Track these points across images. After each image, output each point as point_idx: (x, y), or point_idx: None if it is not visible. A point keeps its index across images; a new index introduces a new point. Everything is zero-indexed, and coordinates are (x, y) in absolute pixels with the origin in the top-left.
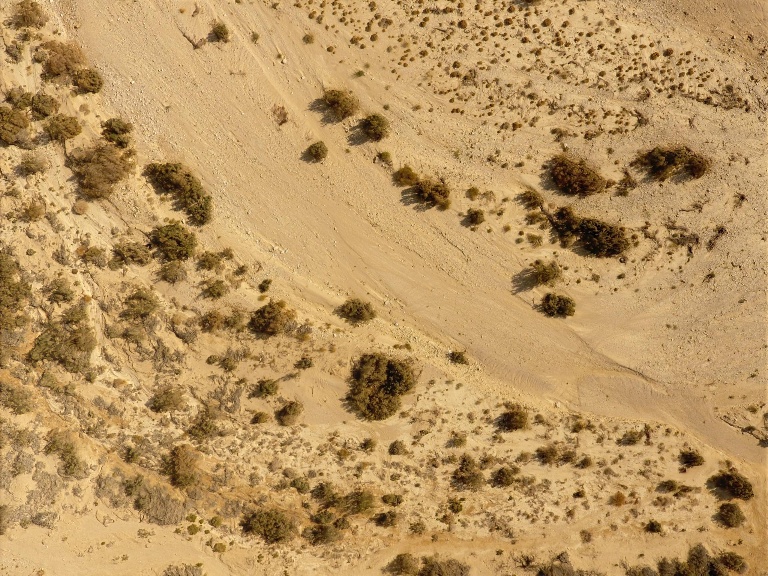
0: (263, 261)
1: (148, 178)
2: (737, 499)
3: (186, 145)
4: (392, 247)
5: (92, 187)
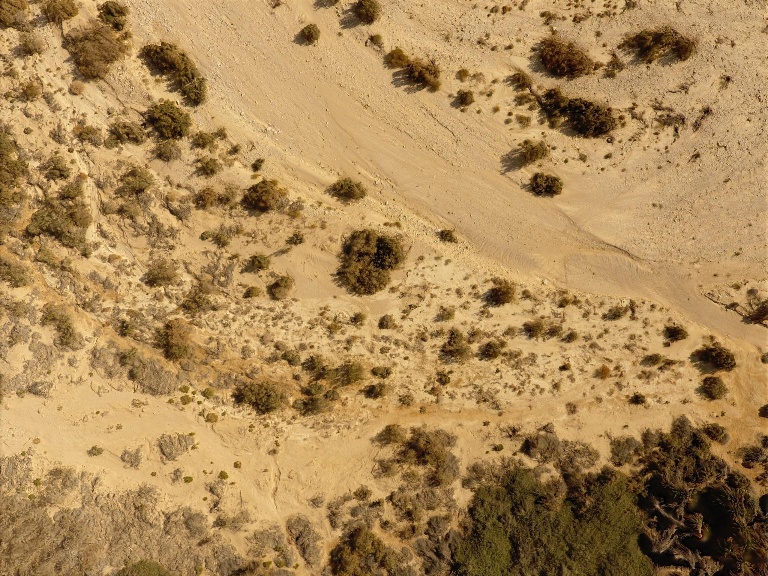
0: (256, 141)
1: (143, 60)
2: (720, 372)
3: (181, 28)
4: (383, 128)
5: (88, 65)
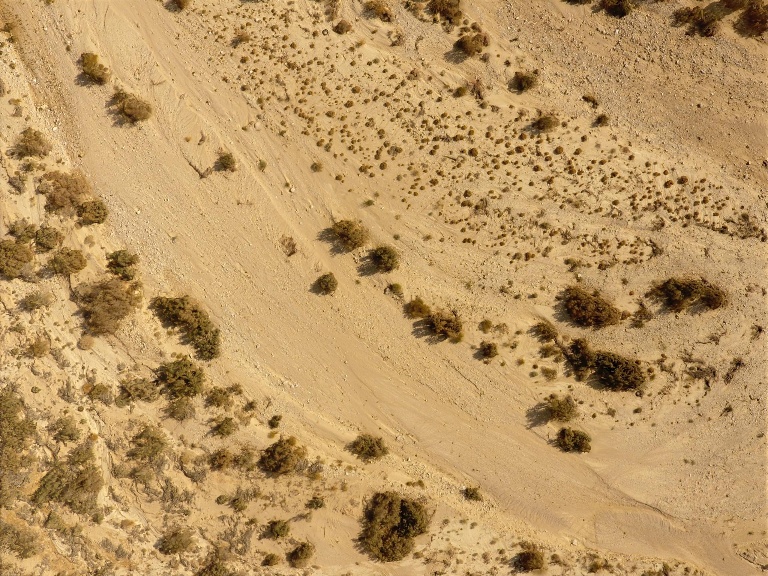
0: (273, 396)
1: (155, 311)
2: None
3: (193, 277)
4: (404, 381)
5: (98, 326)
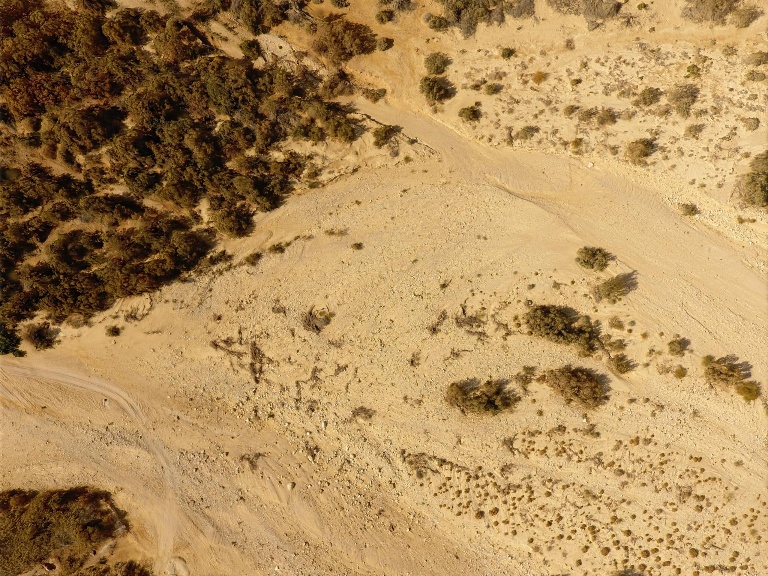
0: None
1: None
2: None
3: None
4: (759, 320)
5: None
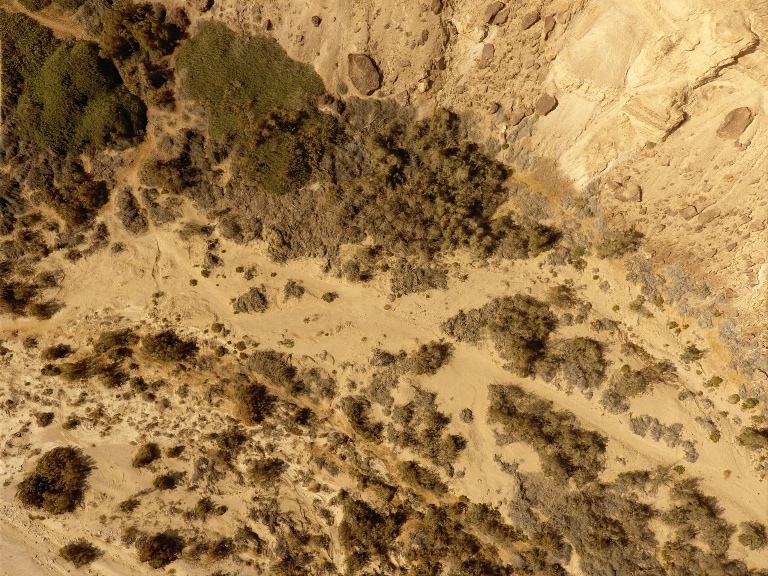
0: None
1: None
2: None
3: None
4: None
5: None
